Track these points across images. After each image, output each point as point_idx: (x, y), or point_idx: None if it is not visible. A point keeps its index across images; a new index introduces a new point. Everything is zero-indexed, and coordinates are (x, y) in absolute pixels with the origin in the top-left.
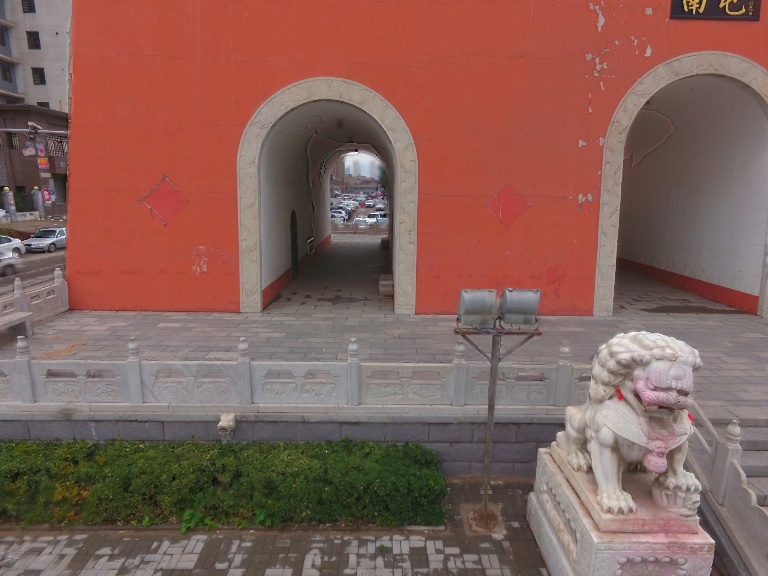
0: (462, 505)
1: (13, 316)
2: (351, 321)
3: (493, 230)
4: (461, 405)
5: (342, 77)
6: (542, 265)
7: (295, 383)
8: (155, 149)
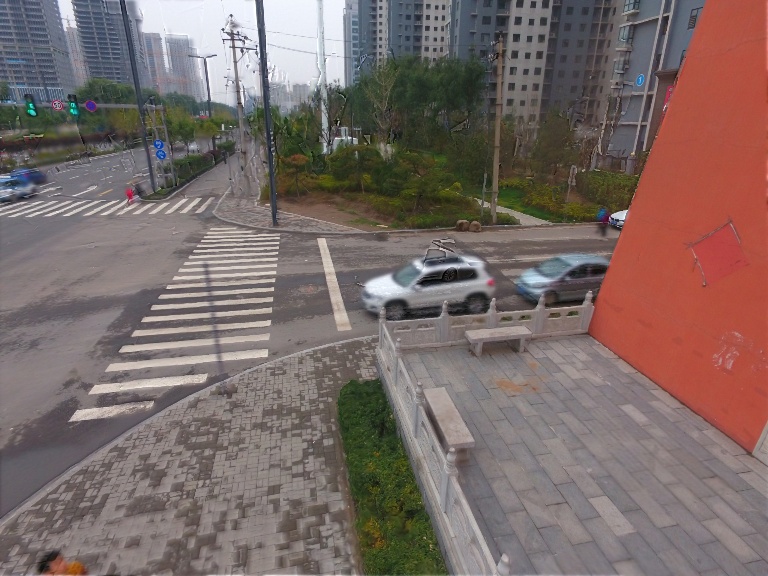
0: None
1: (515, 330)
2: None
3: None
4: None
5: None
6: None
7: None
8: (734, 180)
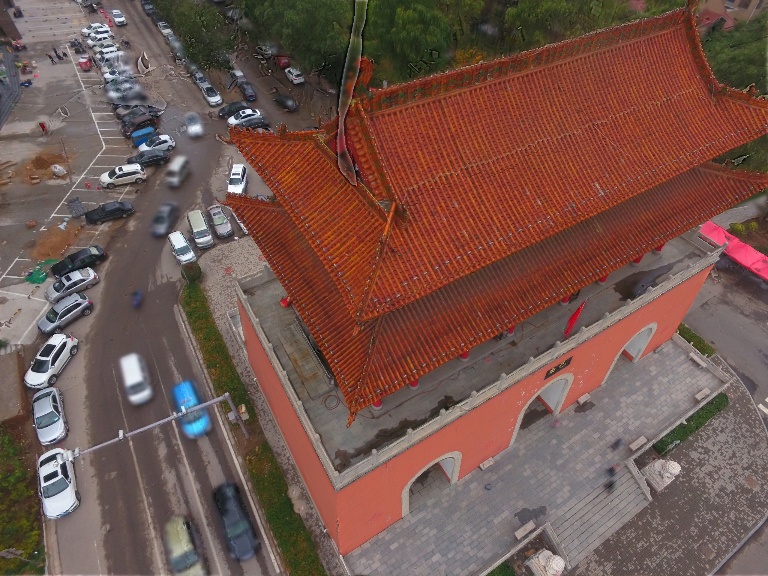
0: (514, 566)
1: None
2: (444, 503)
3: None
4: None
5: None
6: None
7: None
8: None
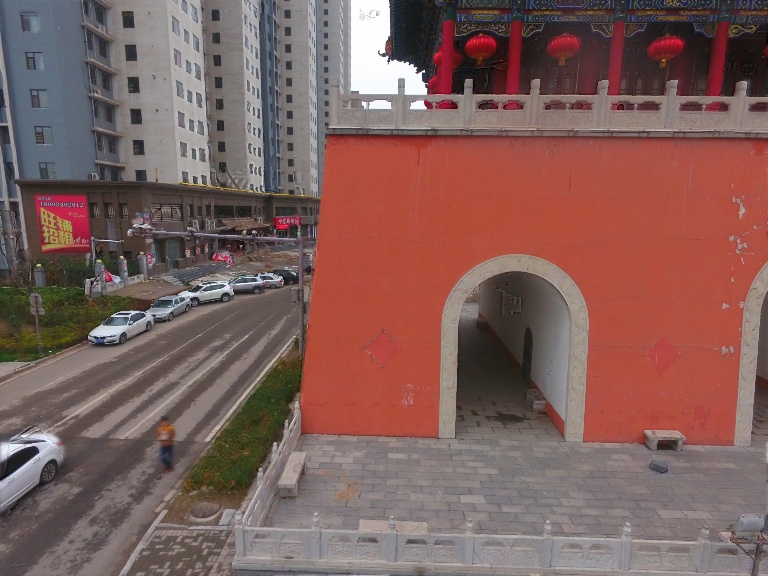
0: None
1: (297, 458)
2: (537, 452)
3: (649, 374)
4: (705, 572)
5: (529, 254)
6: (691, 403)
7: (582, 553)
8: (377, 308)
